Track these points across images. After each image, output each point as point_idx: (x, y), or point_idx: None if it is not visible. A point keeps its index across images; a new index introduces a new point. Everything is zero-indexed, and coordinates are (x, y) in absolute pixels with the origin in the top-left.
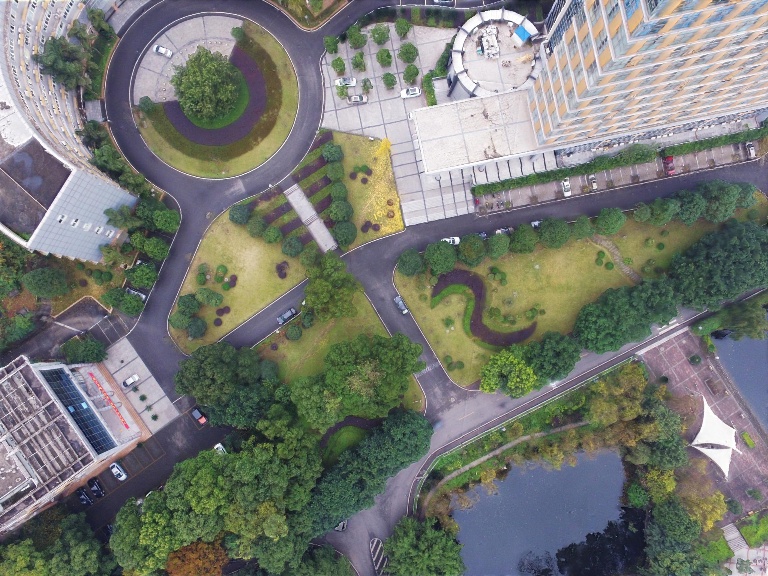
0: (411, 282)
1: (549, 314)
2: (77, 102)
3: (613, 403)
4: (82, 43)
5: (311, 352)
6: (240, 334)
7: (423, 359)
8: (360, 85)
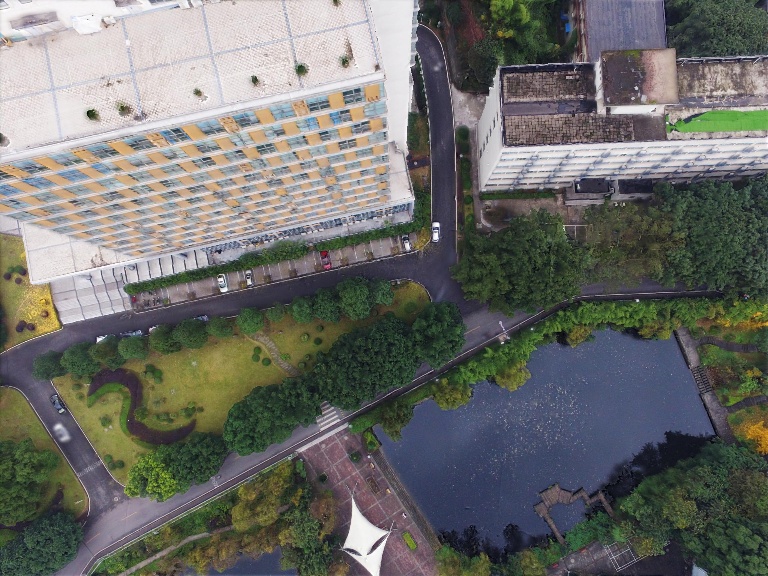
0: (68, 381)
1: (208, 411)
2: None
3: (248, 508)
4: None
5: None
6: None
7: (84, 458)
8: None
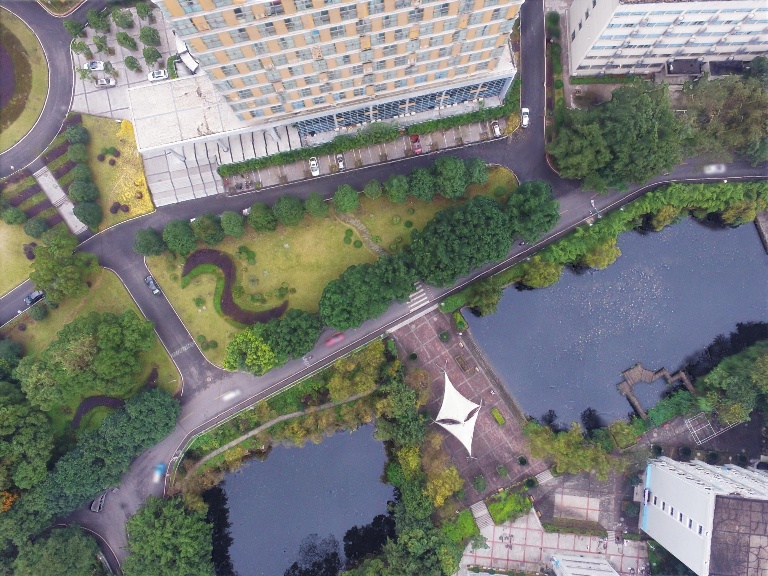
0: (162, 262)
1: (300, 293)
2: None
3: (347, 379)
4: None
5: None
6: None
7: (178, 339)
8: None
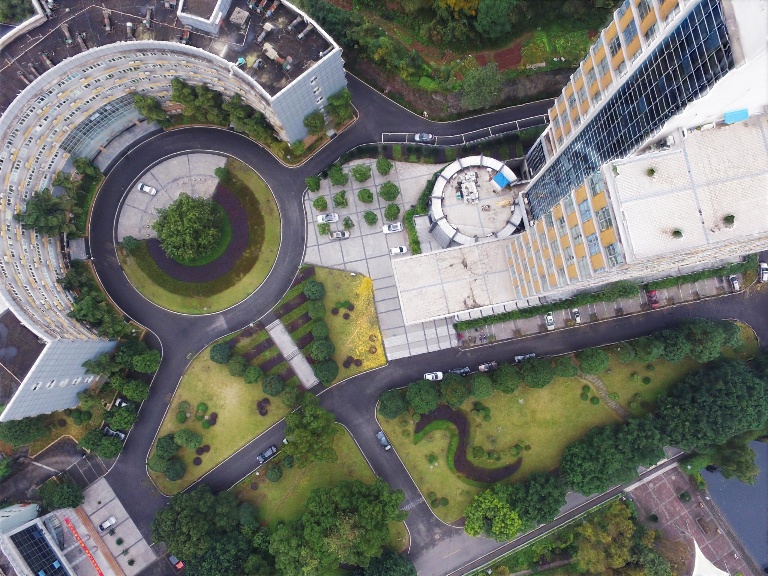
0: None
1: (534, 449)
2: (60, 245)
3: (601, 550)
4: (66, 191)
5: (292, 491)
6: (220, 473)
7: (407, 495)
8: (342, 220)
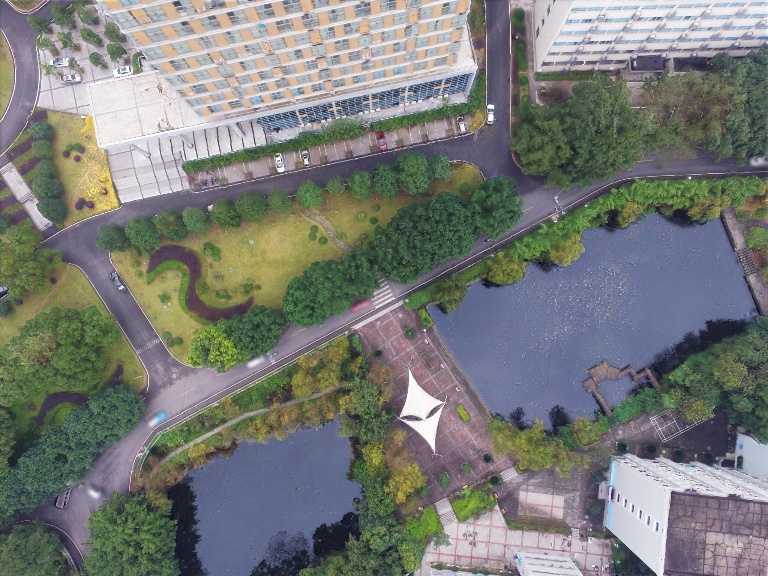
0: (127, 258)
1: (266, 289)
2: None
3: (309, 375)
4: None
5: None
6: None
7: (143, 335)
8: None
